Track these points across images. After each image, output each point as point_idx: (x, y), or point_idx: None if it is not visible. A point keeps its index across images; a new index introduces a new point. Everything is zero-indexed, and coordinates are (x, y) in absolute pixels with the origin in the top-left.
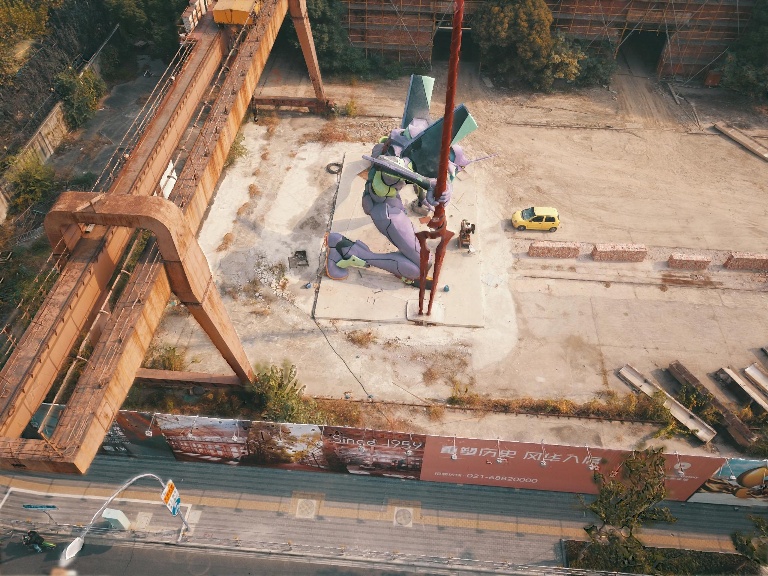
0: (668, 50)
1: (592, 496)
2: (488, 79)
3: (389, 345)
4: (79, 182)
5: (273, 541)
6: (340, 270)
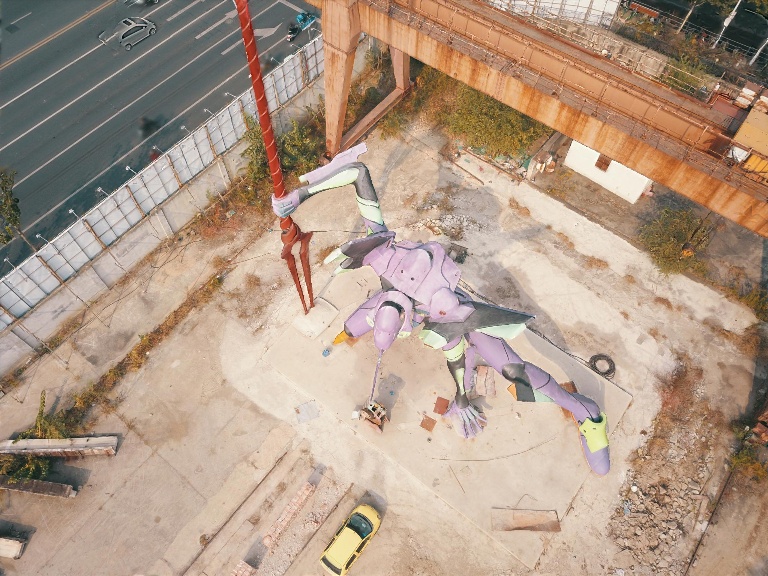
0: None
1: None
2: None
3: None
4: None
5: None
6: None
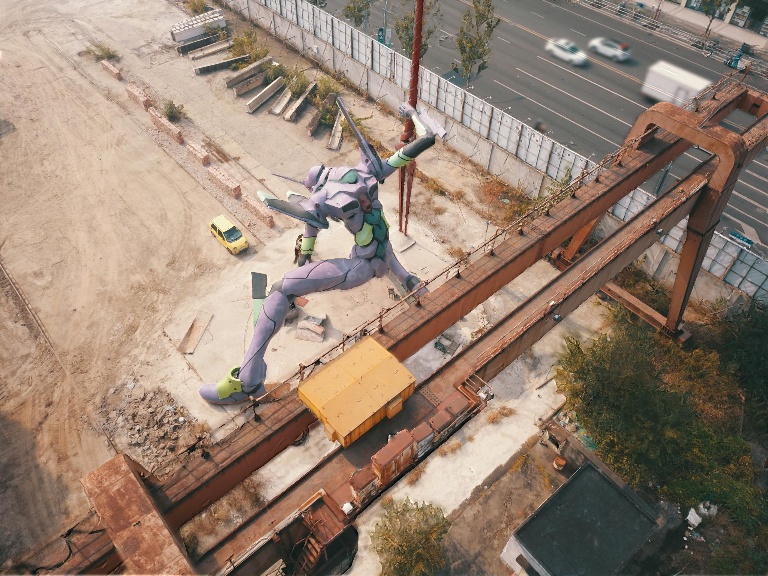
0: None
1: None
2: None
3: (444, 240)
4: None
5: None
6: None
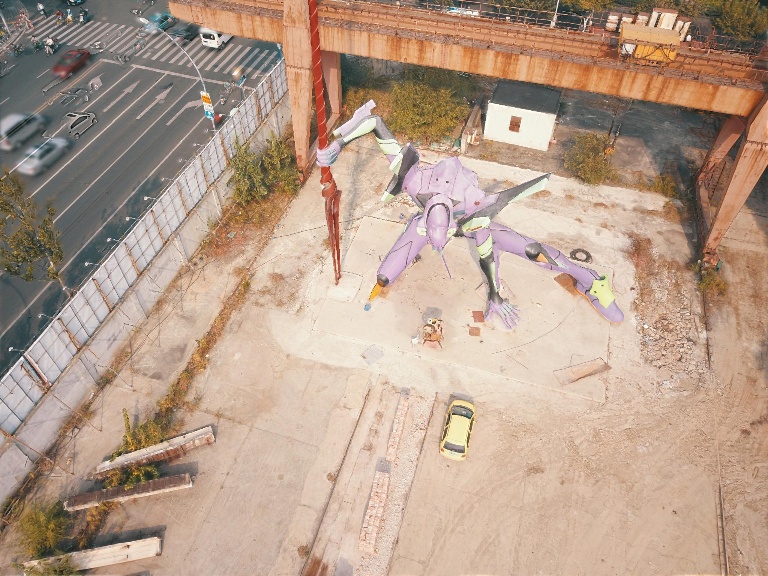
0: None
1: None
2: None
3: (319, 258)
4: None
5: None
6: None
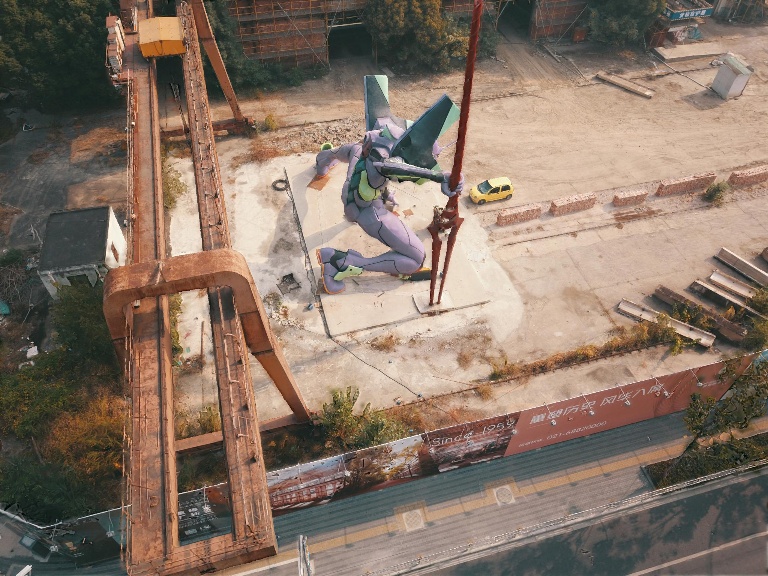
0: (539, 15)
1: (648, 421)
2: (387, 69)
3: (414, 342)
4: (7, 262)
5: (397, 562)
6: (337, 283)
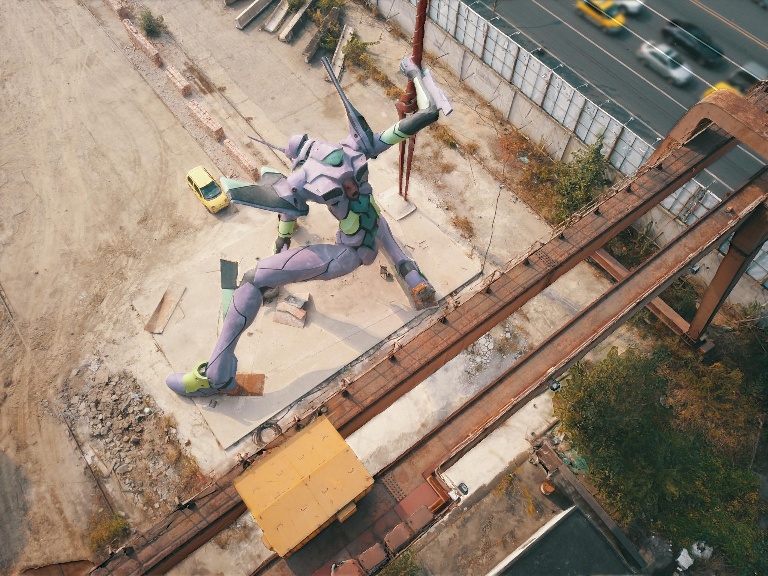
0: None
1: None
2: None
3: (449, 207)
4: None
5: None
6: None
